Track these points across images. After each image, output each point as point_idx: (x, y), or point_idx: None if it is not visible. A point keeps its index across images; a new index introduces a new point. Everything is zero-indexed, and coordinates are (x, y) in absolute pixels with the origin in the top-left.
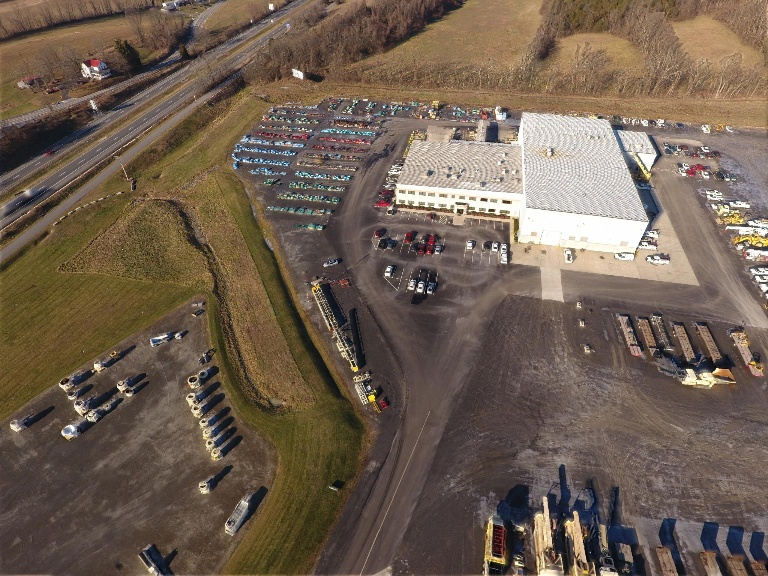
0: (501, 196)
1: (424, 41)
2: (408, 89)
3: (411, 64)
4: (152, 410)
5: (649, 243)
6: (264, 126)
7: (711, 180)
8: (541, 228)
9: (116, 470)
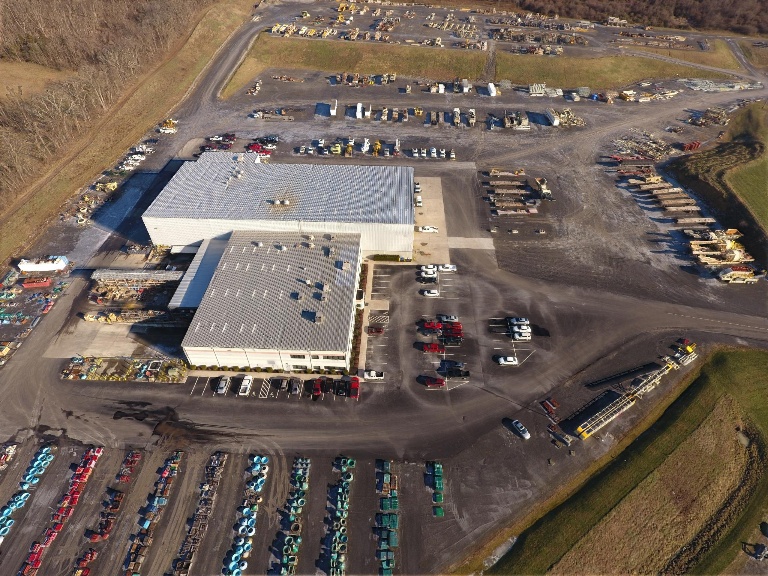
0: None
1: None
2: None
3: None
4: None
5: None
6: None
7: None
8: None
9: None
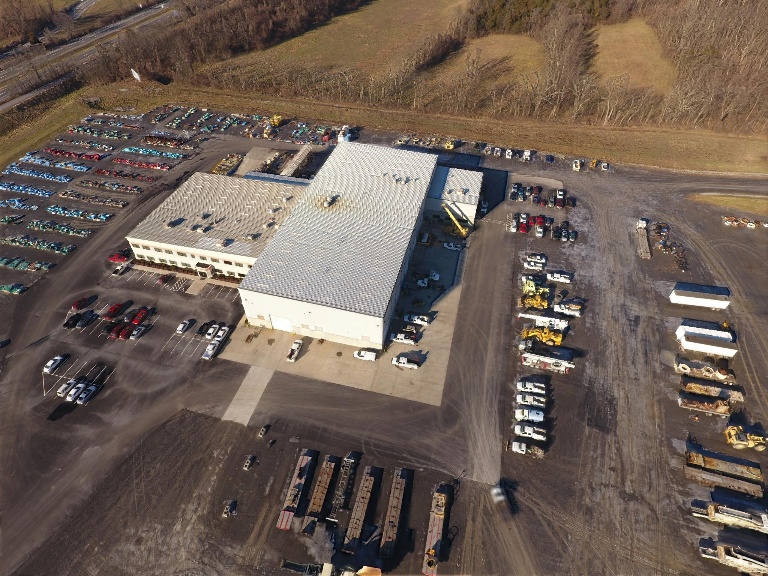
0: (245, 260)
1: (318, 37)
2: (262, 97)
3: (284, 65)
4: None
5: (407, 335)
6: (61, 140)
7: (545, 239)
8: (266, 312)
9: None
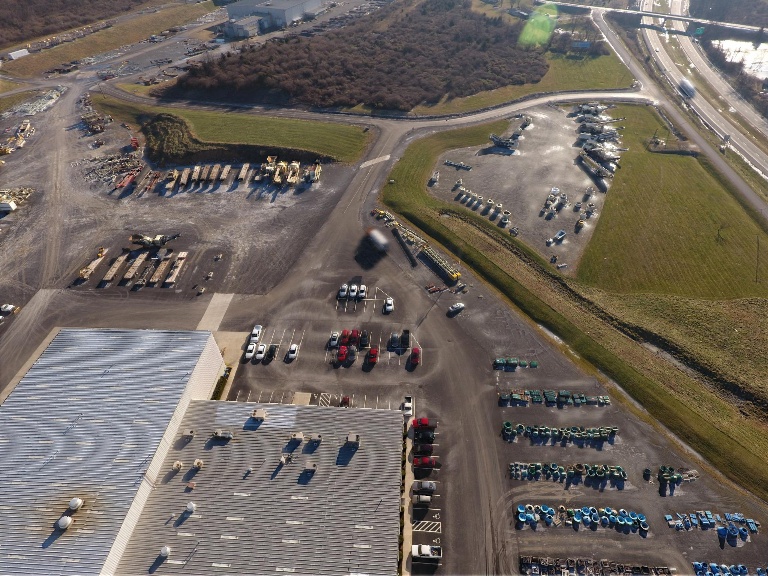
0: None
1: None
2: None
3: None
4: (521, 206)
5: None
6: None
7: None
8: None
9: (513, 186)
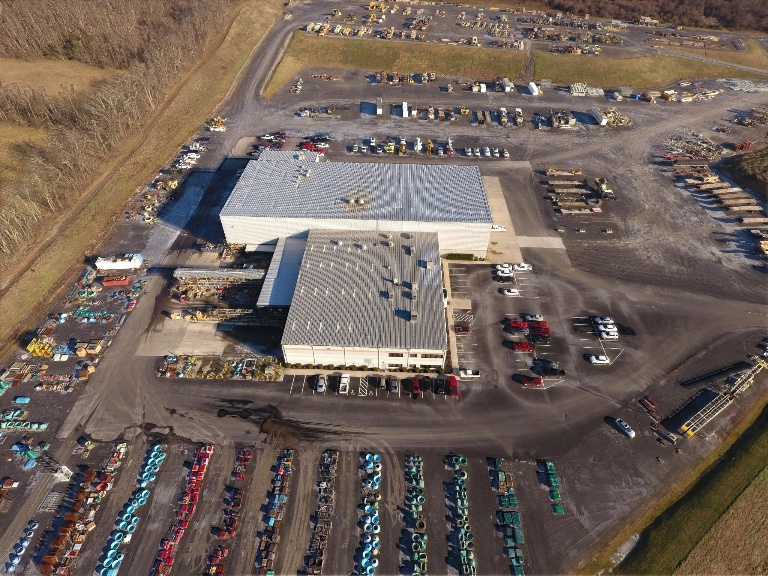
0: None
1: None
2: None
3: None
4: None
5: None
6: None
7: None
8: None
9: None
